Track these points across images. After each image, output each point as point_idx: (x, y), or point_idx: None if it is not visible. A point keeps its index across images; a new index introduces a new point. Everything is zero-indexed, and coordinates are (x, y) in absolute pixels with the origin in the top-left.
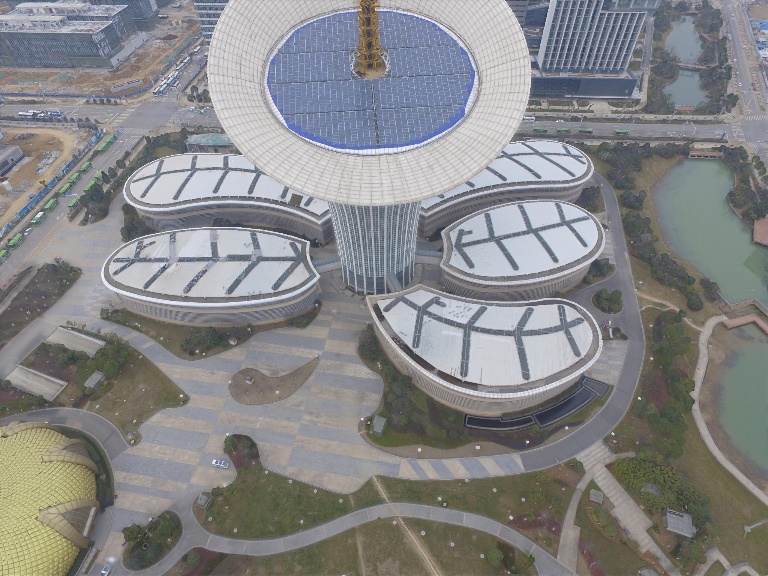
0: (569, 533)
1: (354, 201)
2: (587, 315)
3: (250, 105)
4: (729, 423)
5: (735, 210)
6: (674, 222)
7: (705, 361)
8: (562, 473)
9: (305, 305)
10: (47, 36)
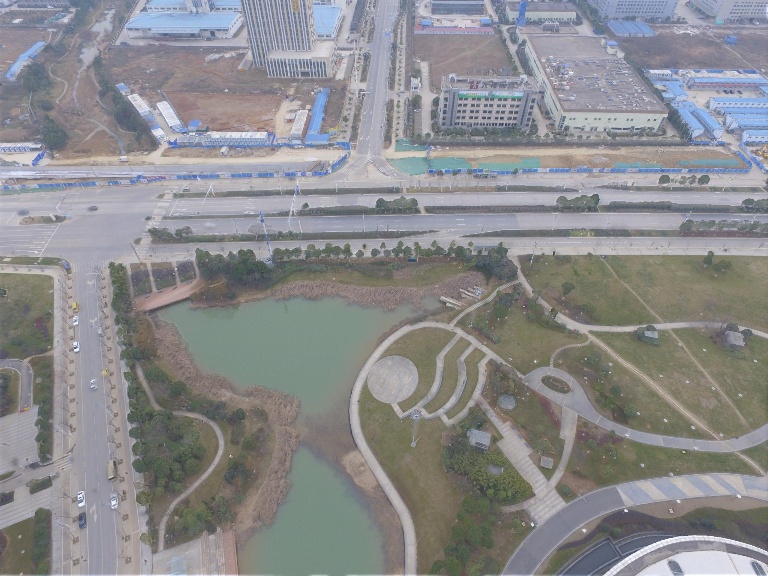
0: (569, 433)
1: None
2: None
3: None
4: (375, 567)
5: None
6: None
7: None
8: (579, 486)
9: None
10: None
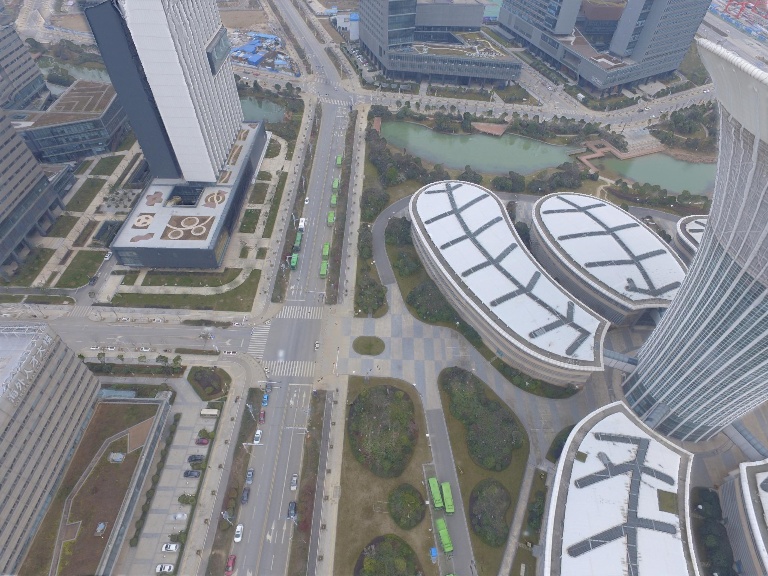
0: None
1: None
2: (688, 219)
3: None
4: None
5: (461, 134)
6: (486, 166)
7: None
8: None
9: None
10: None
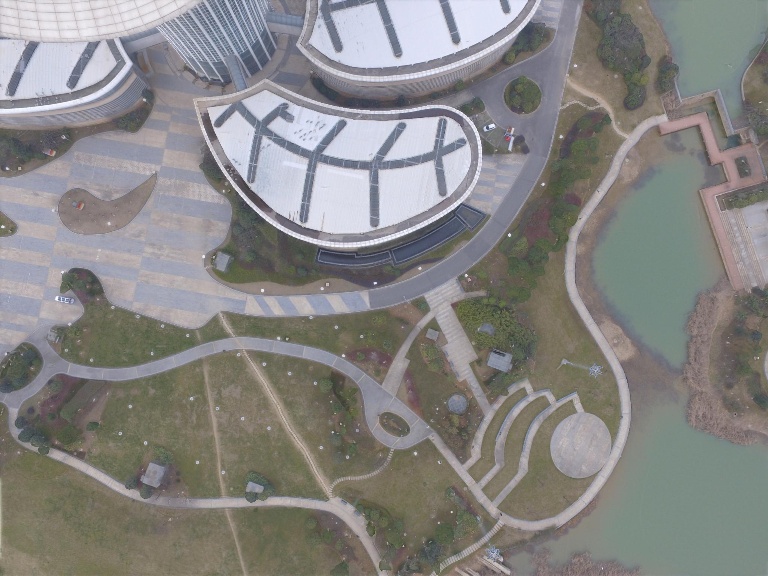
0: (398, 365)
1: (31, 34)
2: (473, 134)
3: None
4: (601, 256)
5: None
6: None
7: (611, 181)
8: (406, 311)
9: (129, 100)
10: None
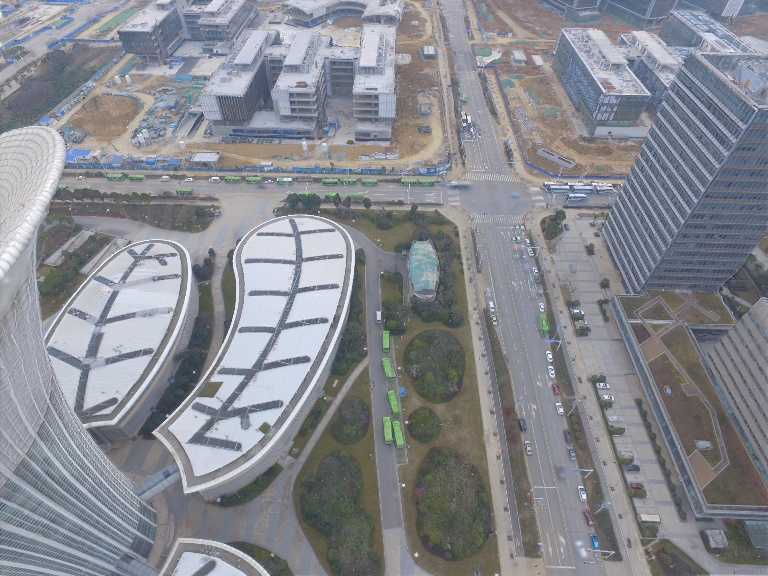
0: None
1: None
2: None
3: None
4: None
5: None
6: None
7: None
8: None
9: None
10: (585, 70)
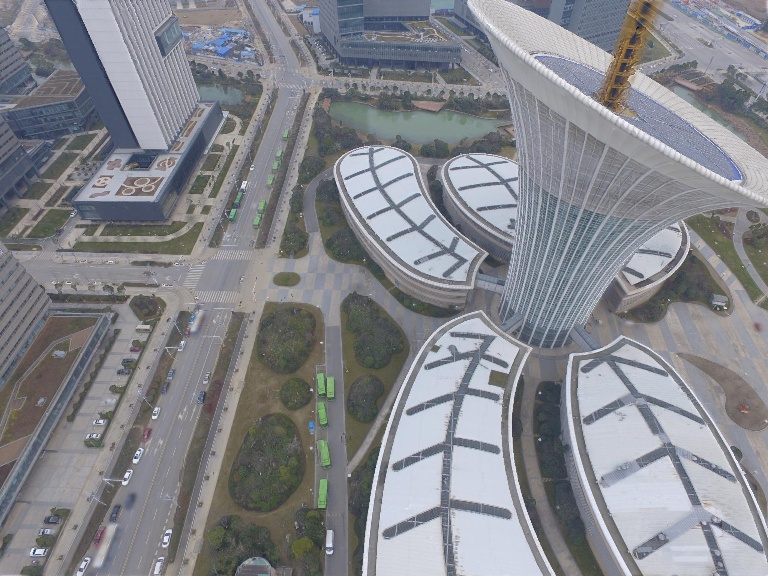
0: None
1: None
2: None
3: (759, 193)
4: None
5: (401, 111)
6: (419, 137)
7: None
8: None
9: None
10: None
